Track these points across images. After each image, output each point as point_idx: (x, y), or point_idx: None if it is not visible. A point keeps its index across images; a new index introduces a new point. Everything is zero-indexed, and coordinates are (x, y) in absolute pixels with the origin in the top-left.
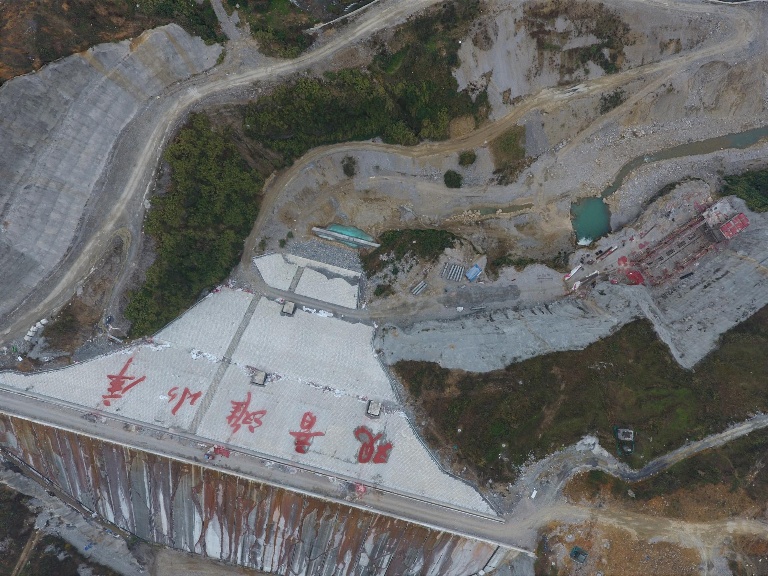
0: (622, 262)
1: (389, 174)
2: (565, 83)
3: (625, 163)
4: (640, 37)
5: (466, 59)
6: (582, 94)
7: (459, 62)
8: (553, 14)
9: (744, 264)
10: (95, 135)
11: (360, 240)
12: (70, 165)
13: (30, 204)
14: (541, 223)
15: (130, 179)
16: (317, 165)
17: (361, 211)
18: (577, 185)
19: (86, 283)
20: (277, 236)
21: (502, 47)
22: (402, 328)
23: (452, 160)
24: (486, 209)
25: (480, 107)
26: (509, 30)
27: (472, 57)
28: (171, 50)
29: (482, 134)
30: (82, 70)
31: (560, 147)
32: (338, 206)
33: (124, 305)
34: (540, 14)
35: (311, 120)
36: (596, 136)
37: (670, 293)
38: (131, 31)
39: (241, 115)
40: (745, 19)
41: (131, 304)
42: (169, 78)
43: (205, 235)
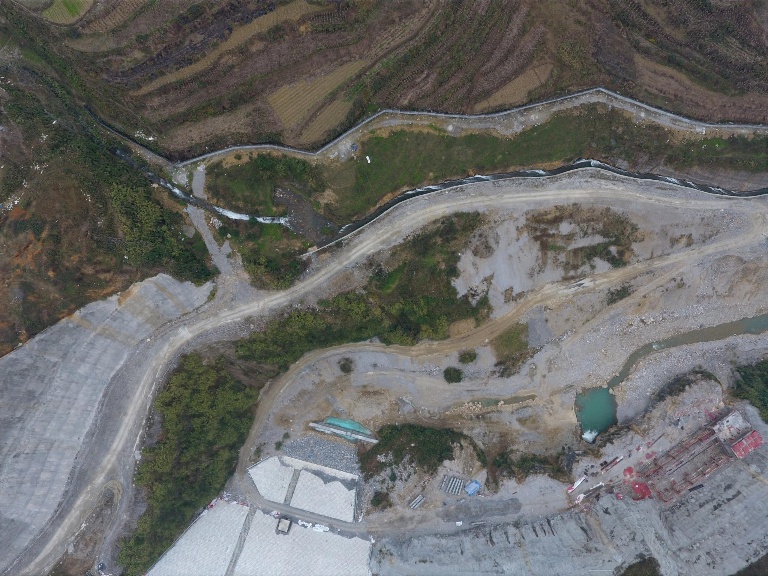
0: (628, 473)
1: (387, 370)
2: (570, 278)
3: (633, 351)
4: (649, 234)
5: (466, 268)
6: (588, 289)
7: (459, 272)
8: (557, 220)
9: (756, 486)
10: (84, 388)
11: (358, 436)
12: (59, 423)
13: (19, 472)
14: (544, 416)
15: (120, 429)
16: (313, 368)
17: (359, 407)
18: (582, 376)
19: (77, 541)
20: (273, 439)
21: (504, 252)
22: (399, 544)
23: (452, 359)
24: (487, 400)
25: (481, 309)
26: (511, 237)
27: (472, 266)
28: (160, 297)
29: (483, 332)
30: (70, 332)
31: (565, 337)
32: (335, 401)
33: (116, 552)
34: (543, 220)
35: (305, 341)
36: (602, 326)
37: (678, 507)
38: (119, 285)
39: (233, 345)
40: (762, 213)
41: (123, 552)
42: (159, 320)
43: (198, 466)
